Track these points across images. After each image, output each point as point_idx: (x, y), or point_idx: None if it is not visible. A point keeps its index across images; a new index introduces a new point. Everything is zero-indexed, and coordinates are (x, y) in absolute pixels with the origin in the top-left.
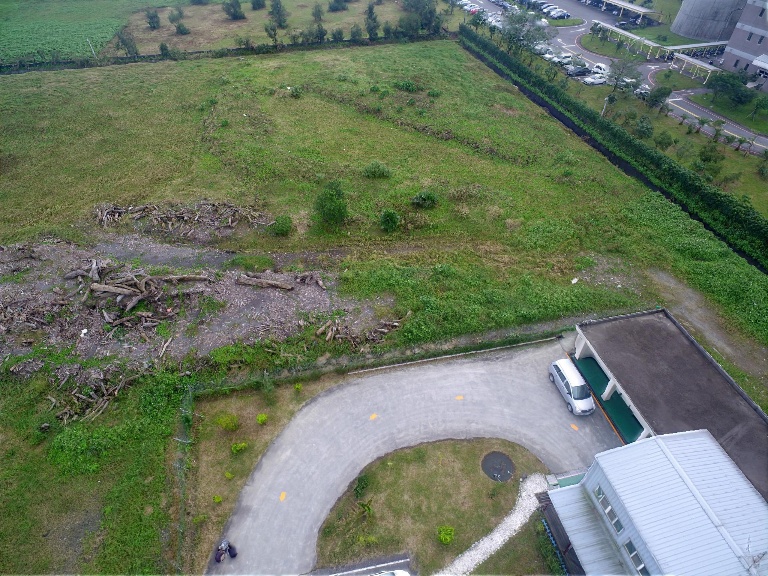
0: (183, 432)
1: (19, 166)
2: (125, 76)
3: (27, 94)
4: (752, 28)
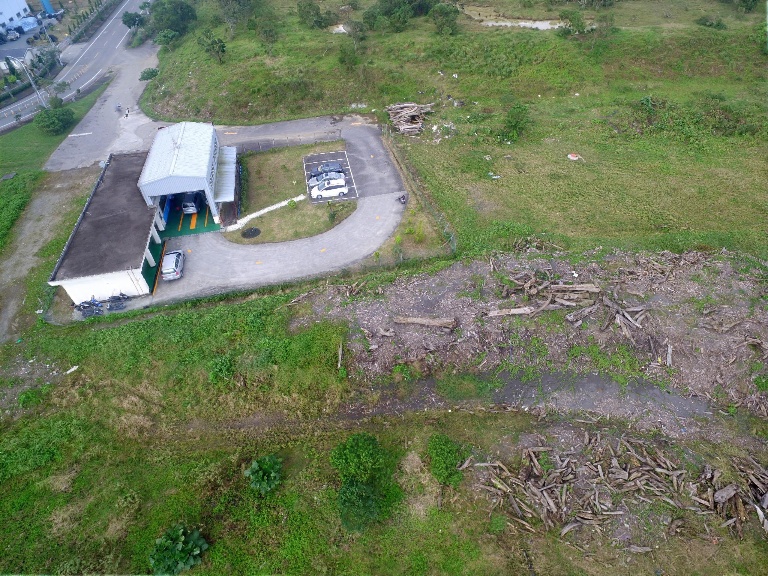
0: None
1: None
2: None
3: None
4: None
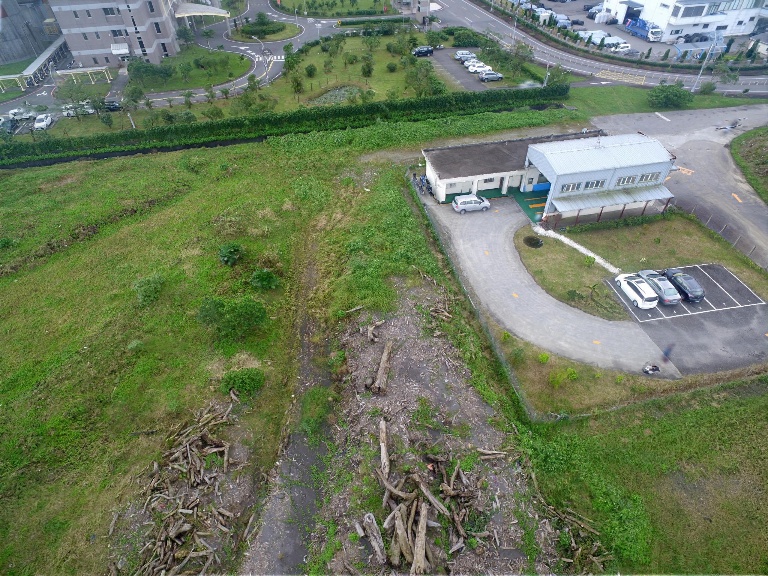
0: (570, 426)
1: None
2: None
3: None
4: (80, 29)
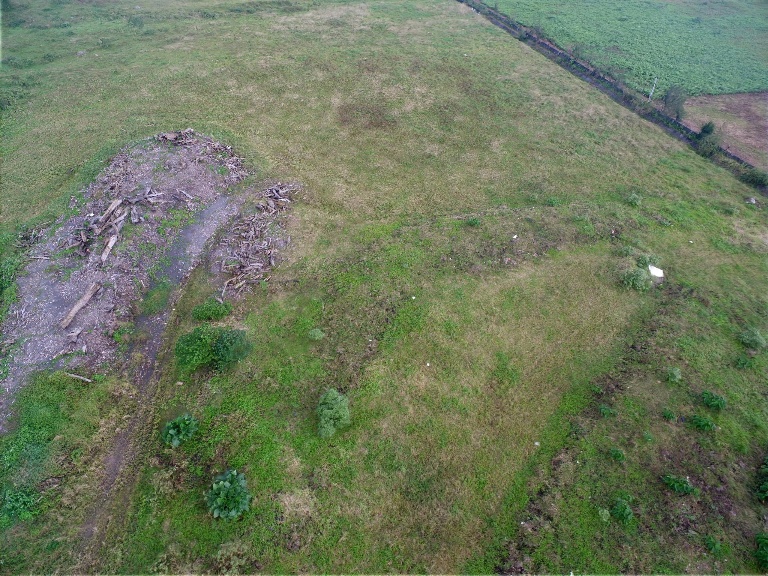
0: None
1: (375, 130)
2: (605, 129)
3: (527, 95)
4: None
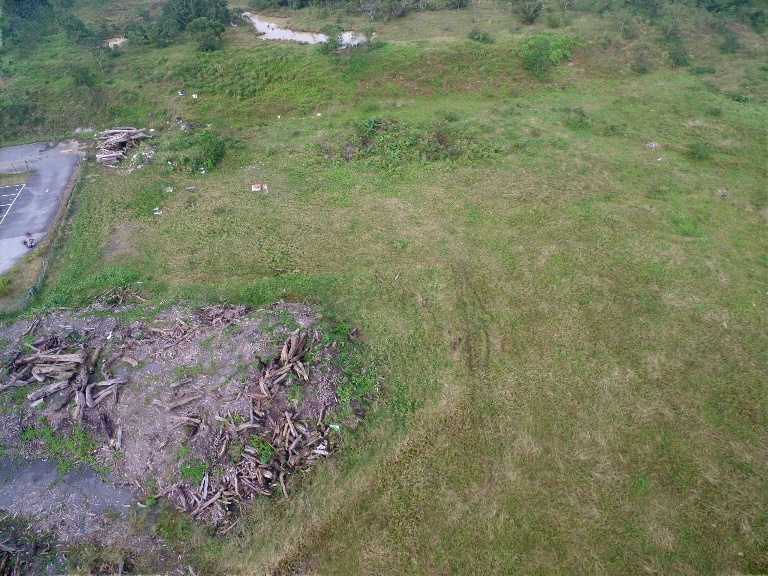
0: None
1: None
2: None
3: None
4: None
